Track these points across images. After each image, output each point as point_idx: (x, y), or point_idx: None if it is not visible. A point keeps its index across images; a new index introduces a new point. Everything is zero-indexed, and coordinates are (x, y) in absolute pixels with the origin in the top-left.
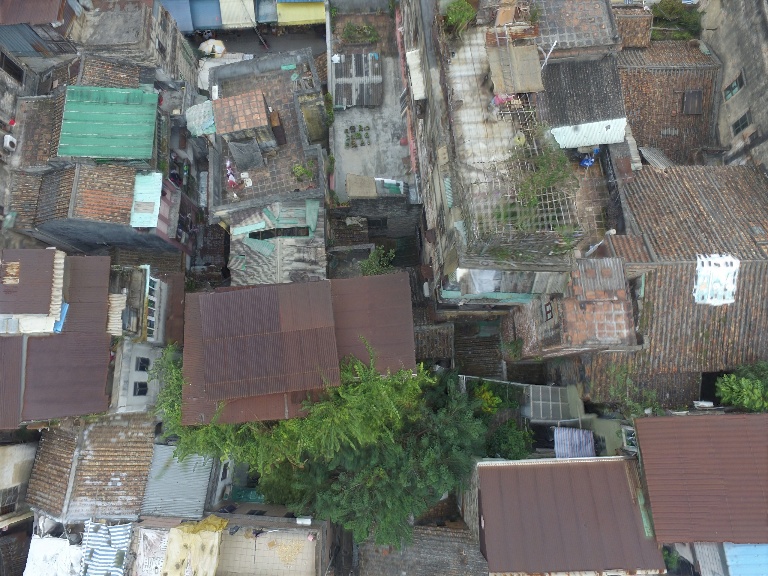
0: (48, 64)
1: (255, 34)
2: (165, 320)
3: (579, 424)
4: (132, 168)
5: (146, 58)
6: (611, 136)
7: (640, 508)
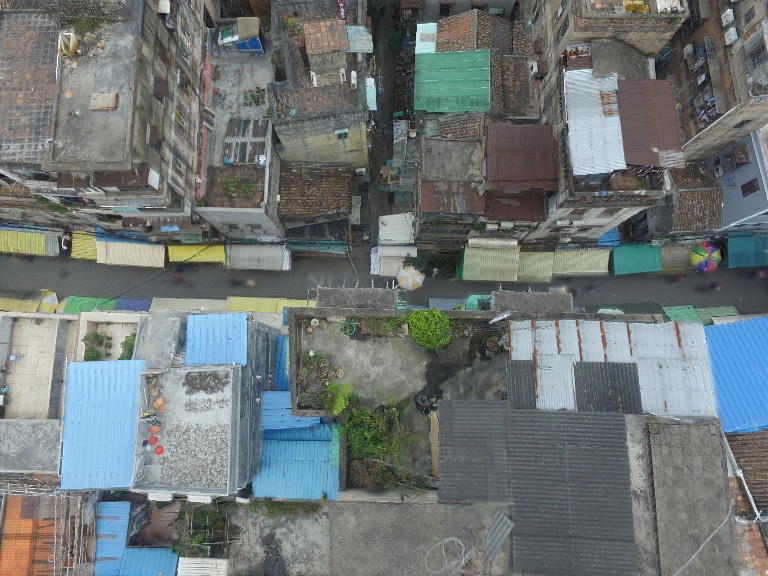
0: None
1: None
2: None
3: None
4: None
5: None
6: None
7: None
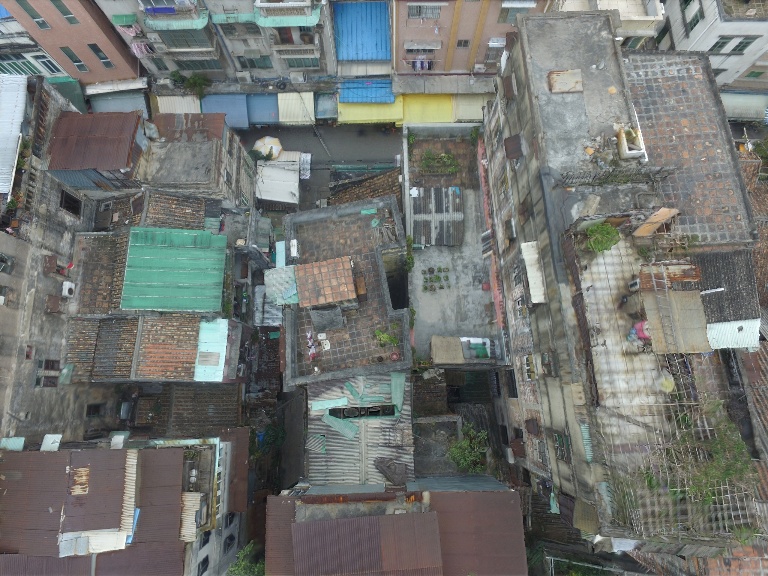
0: (108, 194)
1: (310, 124)
2: (229, 485)
3: None
4: (197, 315)
5: (214, 193)
6: (744, 339)
7: None
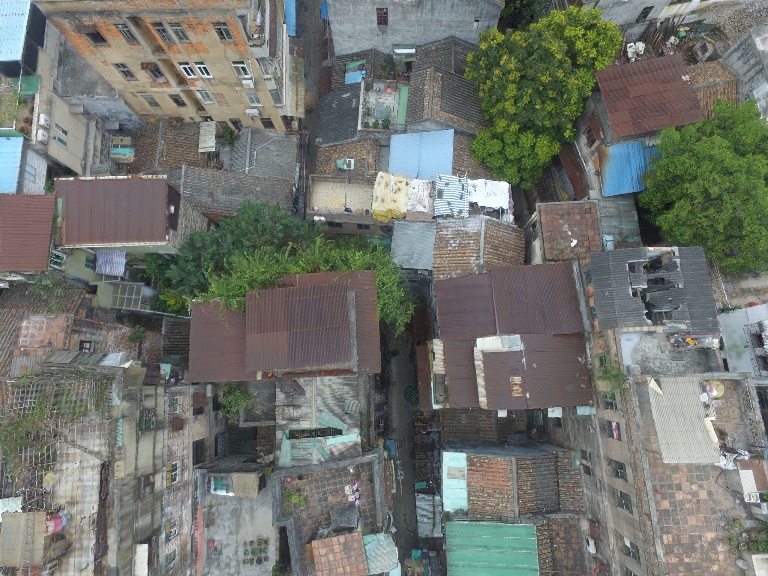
0: None
1: None
2: None
3: (104, 278)
4: (471, 516)
5: None
6: None
7: (61, 215)
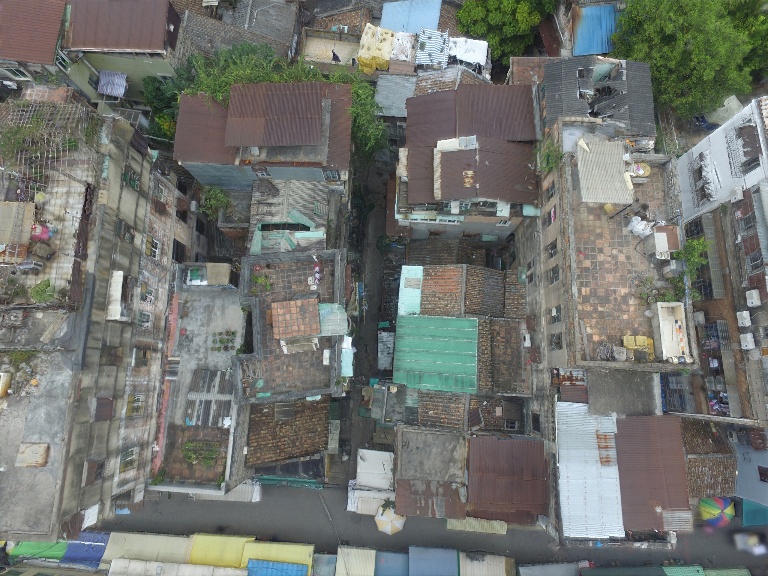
0: None
1: None
2: None
3: (105, 99)
4: None
5: None
6: None
7: (70, 20)
